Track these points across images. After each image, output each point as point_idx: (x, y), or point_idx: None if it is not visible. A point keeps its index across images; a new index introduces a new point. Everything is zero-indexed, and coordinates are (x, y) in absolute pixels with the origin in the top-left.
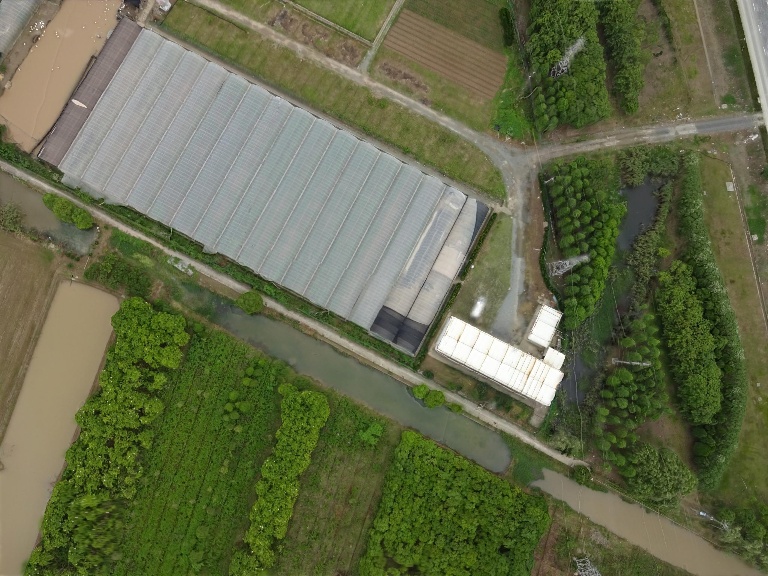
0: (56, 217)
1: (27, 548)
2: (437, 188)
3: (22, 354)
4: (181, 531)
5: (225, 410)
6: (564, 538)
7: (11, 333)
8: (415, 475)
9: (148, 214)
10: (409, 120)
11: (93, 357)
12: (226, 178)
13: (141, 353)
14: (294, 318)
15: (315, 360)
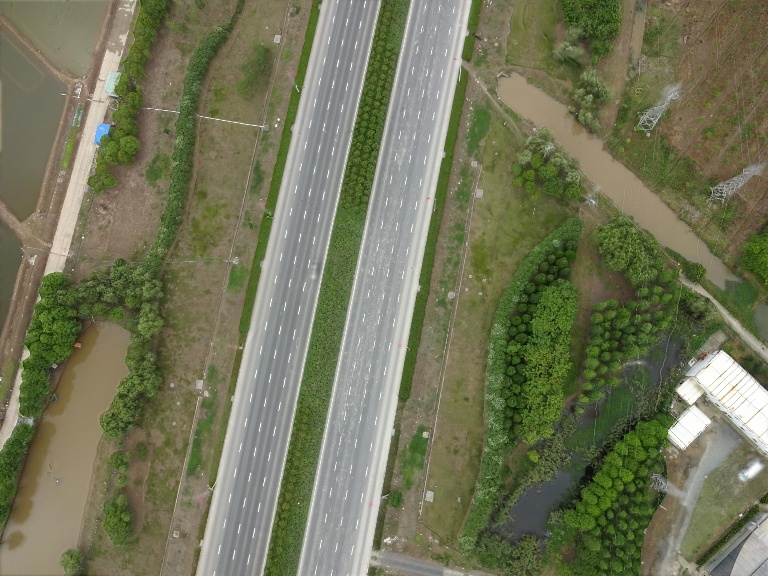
0: None
1: None
2: None
3: None
4: None
5: None
6: (726, 222)
7: None
8: None
9: None
10: None
11: None
12: None
13: None
14: None
15: None
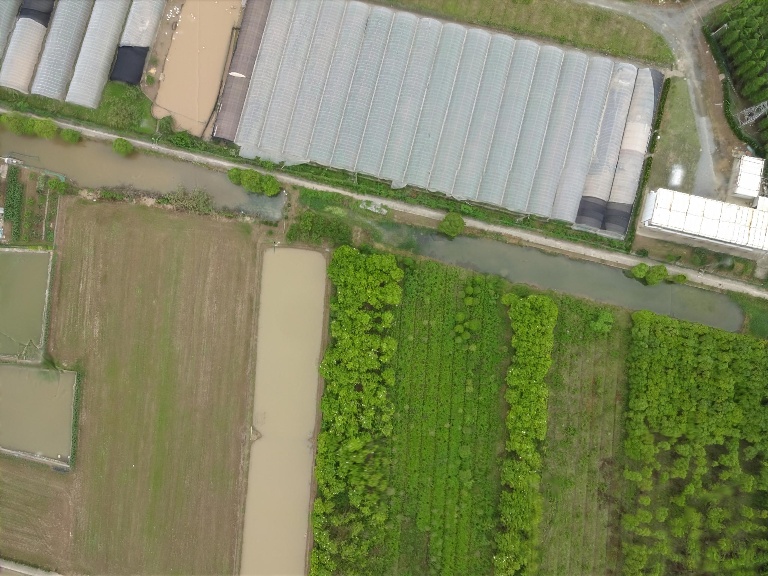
0: (243, 191)
1: (303, 504)
2: (607, 67)
3: (248, 327)
4: (444, 455)
5: (456, 332)
6: None
7: (233, 310)
8: (662, 349)
9: (331, 165)
10: (557, 8)
11: (314, 314)
12: (396, 111)
13: (365, 297)
14: (495, 231)
15: (525, 267)
